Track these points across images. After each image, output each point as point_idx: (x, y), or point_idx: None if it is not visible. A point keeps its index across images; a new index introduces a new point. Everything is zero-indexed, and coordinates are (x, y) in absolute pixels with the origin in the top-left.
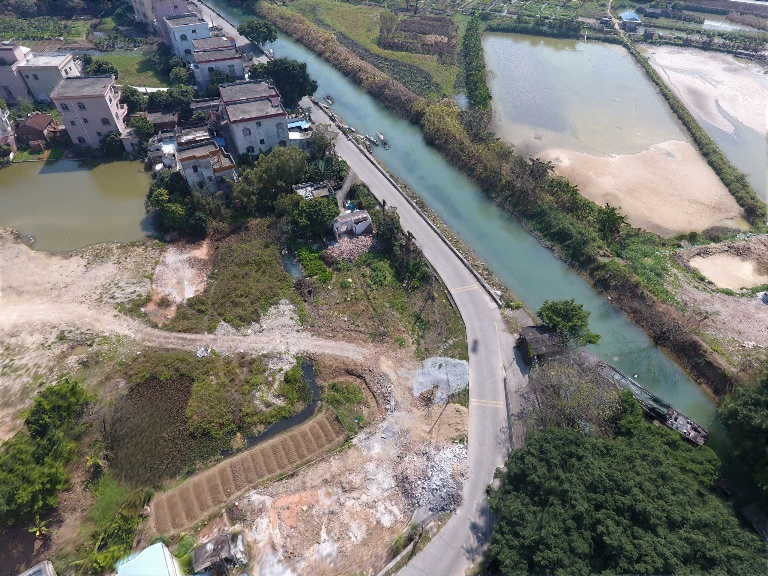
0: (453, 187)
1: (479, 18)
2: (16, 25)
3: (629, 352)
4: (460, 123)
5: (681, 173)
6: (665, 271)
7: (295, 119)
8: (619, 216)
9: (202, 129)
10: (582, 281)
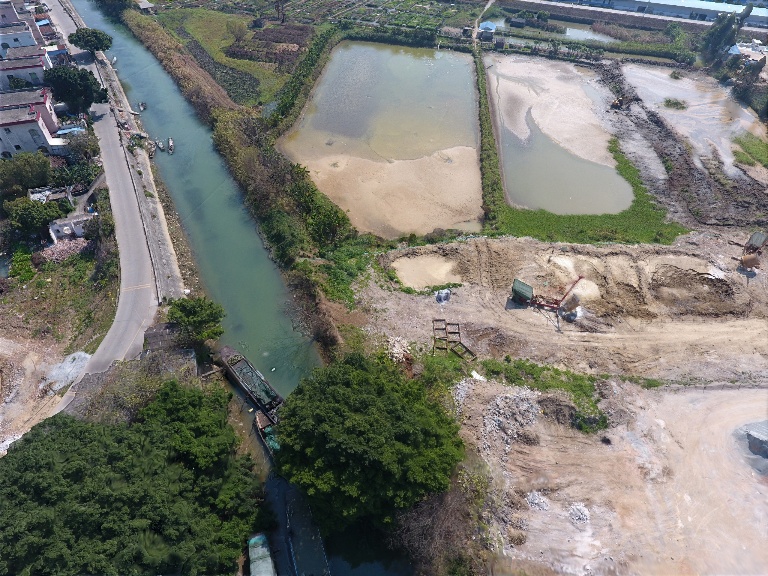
0: (212, 191)
1: (339, 27)
2: None
3: (282, 347)
4: (245, 129)
5: (447, 178)
6: (361, 271)
7: (71, 125)
8: (336, 219)
9: None
10: (281, 280)
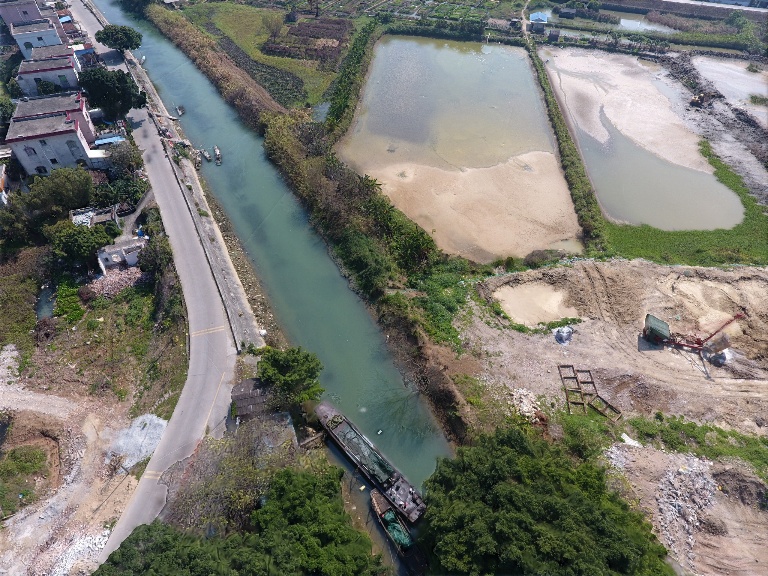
0: (272, 208)
1: (379, 20)
2: None
3: (385, 402)
4: (300, 136)
5: (530, 188)
6: (460, 304)
7: (109, 134)
8: (424, 241)
9: (8, 146)
10: (368, 316)
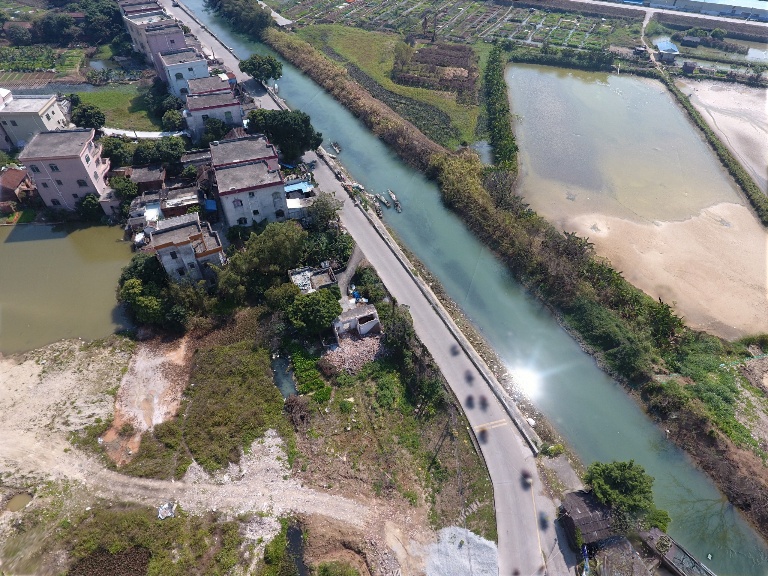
0: (475, 265)
1: (502, 48)
2: (7, 54)
3: (698, 516)
4: (483, 183)
5: (740, 248)
6: (735, 393)
7: (296, 180)
8: (675, 317)
9: (191, 190)
10: (632, 403)
